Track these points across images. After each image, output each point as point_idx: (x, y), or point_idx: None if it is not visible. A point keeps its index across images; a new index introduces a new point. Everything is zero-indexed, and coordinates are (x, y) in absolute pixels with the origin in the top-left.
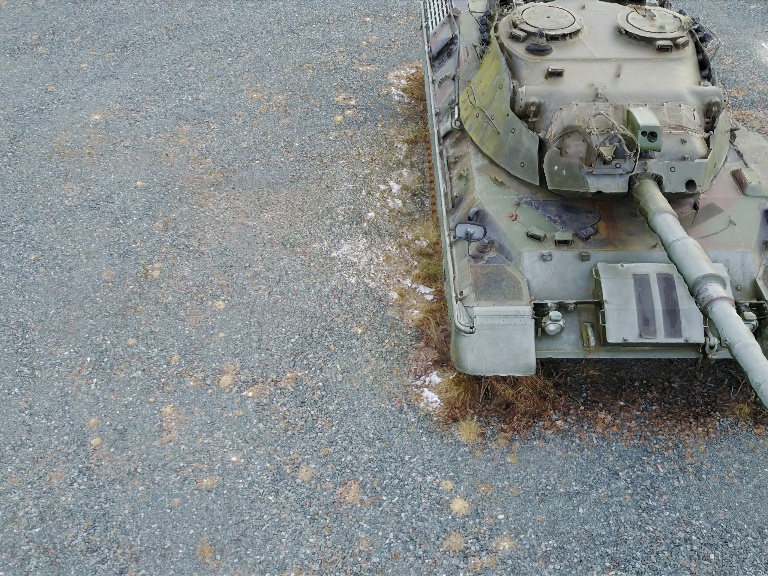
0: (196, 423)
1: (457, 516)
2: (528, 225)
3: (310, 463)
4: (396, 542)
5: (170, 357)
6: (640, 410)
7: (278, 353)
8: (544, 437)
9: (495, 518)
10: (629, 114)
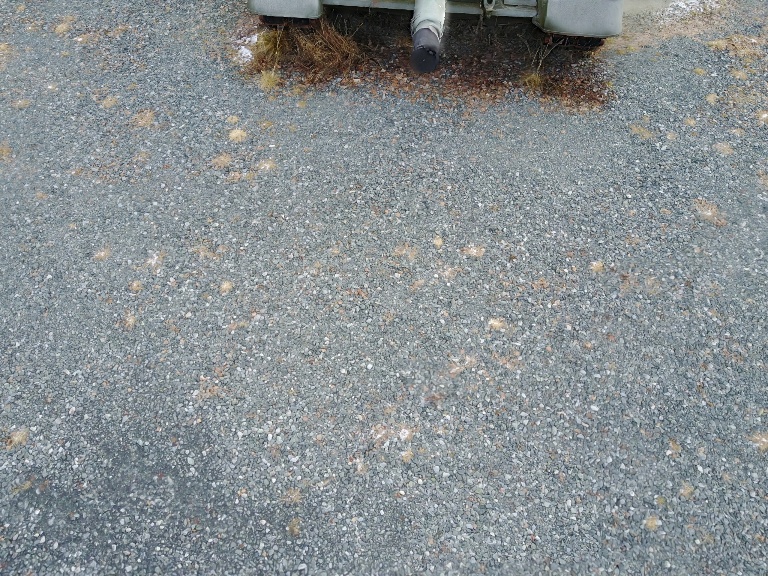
0: (25, 58)
1: (232, 142)
2: None
3: (116, 94)
4: (171, 157)
5: (17, 6)
6: (439, 77)
7: (116, 9)
8: (338, 90)
9: (266, 146)
10: None
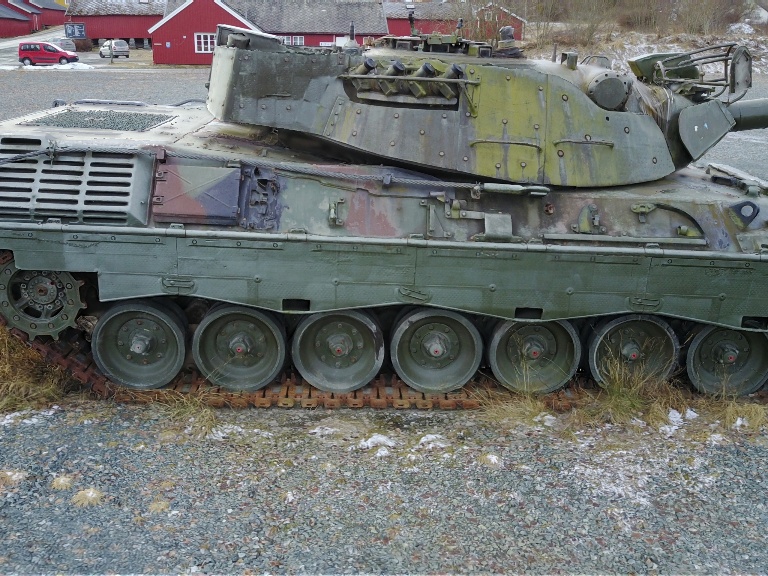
0: None
1: None
2: (740, 194)
3: None
4: None
5: None
6: None
7: None
8: None
9: None
10: (651, 61)
